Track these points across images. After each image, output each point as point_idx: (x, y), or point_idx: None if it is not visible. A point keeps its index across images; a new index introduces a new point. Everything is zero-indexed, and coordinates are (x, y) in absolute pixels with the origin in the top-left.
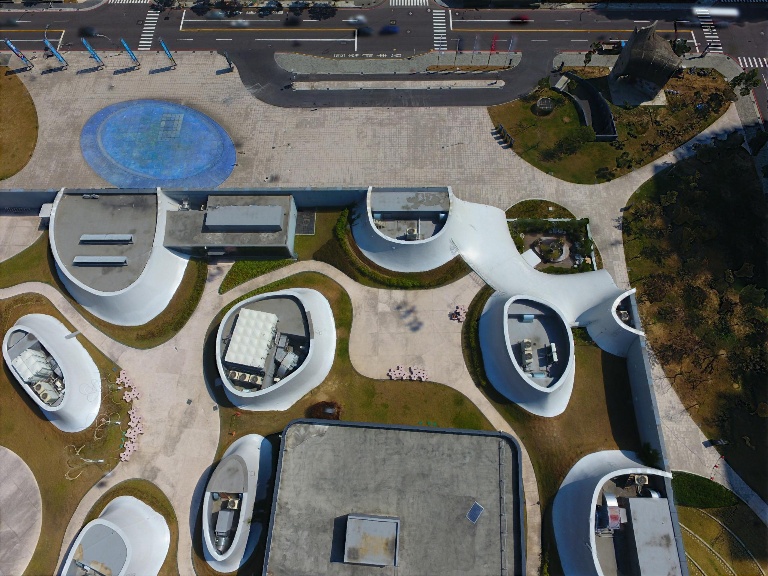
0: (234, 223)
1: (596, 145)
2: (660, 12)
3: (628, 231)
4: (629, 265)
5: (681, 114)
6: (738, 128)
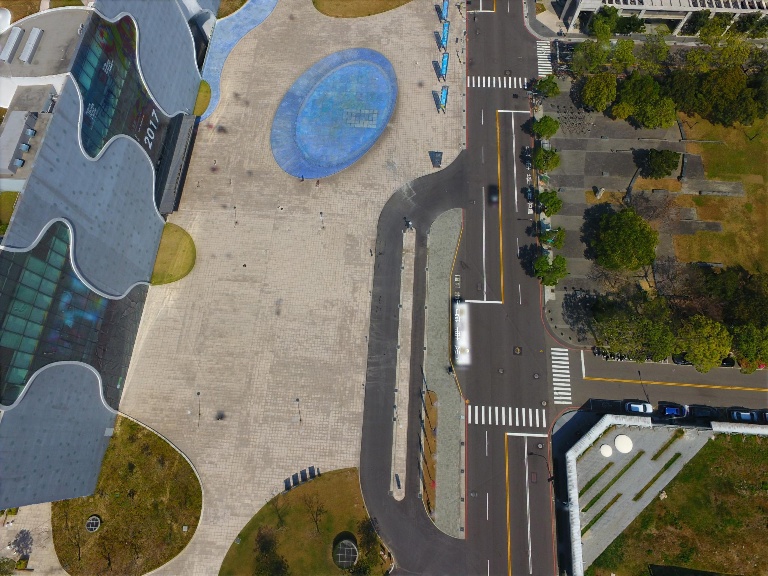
0: (4, 132)
1: None
2: None
3: None
4: None
5: None
6: None
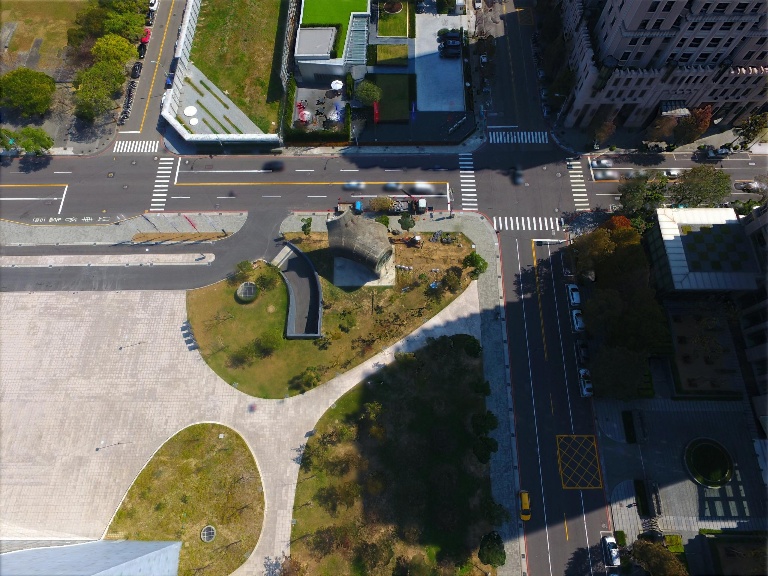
0: None
1: (297, 344)
2: (417, 157)
3: (307, 465)
4: (295, 516)
5: (410, 296)
6: (474, 313)
